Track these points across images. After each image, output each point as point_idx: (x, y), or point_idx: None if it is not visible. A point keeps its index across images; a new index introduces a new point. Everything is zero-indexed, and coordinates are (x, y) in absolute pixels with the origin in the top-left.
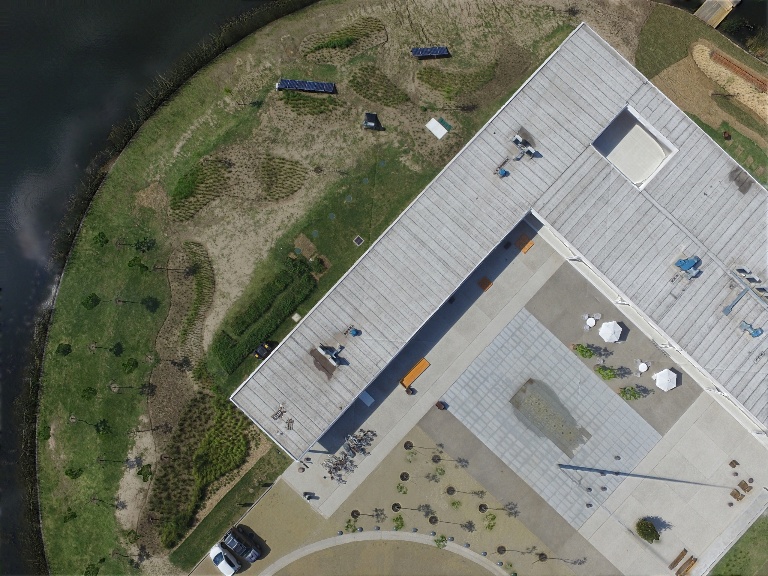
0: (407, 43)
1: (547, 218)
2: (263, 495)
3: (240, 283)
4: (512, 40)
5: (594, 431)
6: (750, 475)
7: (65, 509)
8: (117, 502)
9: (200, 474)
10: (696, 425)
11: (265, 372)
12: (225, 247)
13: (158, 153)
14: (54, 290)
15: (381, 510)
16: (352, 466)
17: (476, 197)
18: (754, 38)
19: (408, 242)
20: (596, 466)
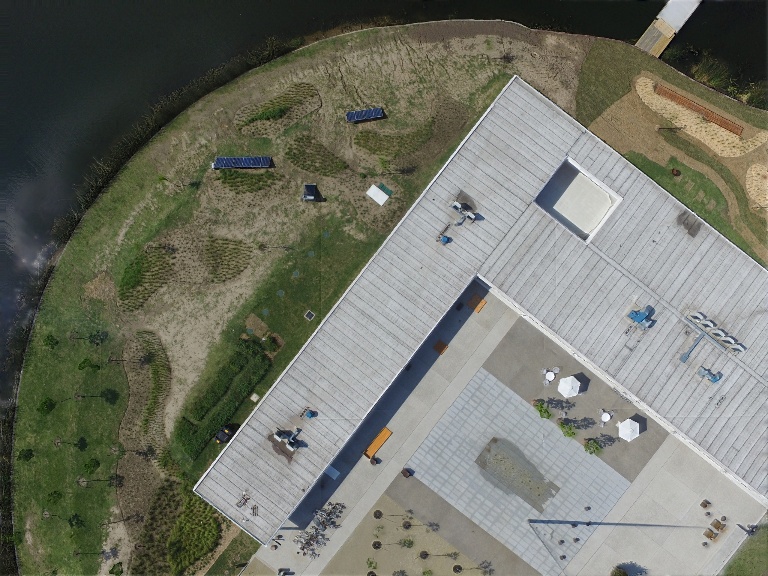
0: (342, 107)
1: (494, 281)
2: (239, 575)
3: (196, 368)
4: (448, 95)
5: (562, 484)
6: (722, 513)
7: None
8: None
9: (174, 561)
10: (664, 468)
11: (225, 461)
12: (177, 333)
13: (103, 242)
14: (15, 387)
15: None
16: (324, 539)
17: (420, 267)
18: (699, 64)
19: (356, 319)
20: (567, 518)
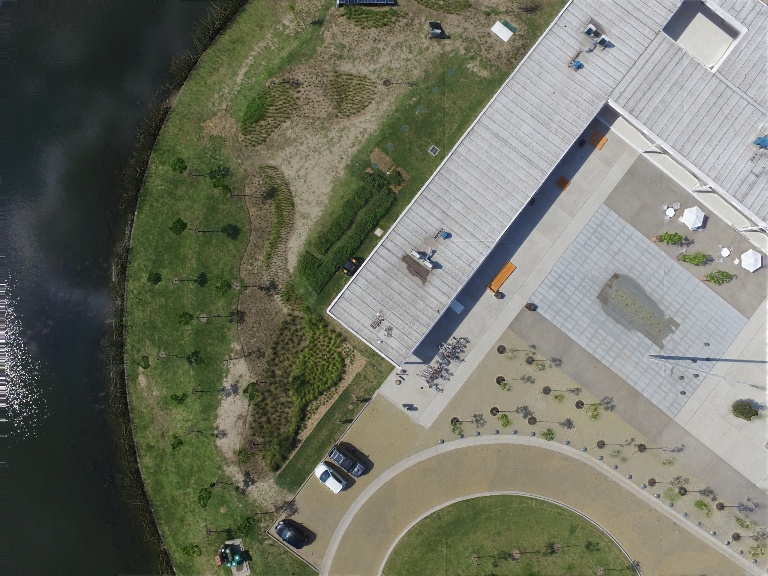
0: None
1: (625, 107)
2: (362, 411)
3: (319, 203)
4: None
5: (682, 320)
6: None
7: (163, 445)
8: (217, 431)
9: (299, 394)
10: None
11: (359, 282)
12: (301, 168)
13: (221, 82)
14: (128, 230)
15: (480, 415)
16: (448, 374)
17: (553, 91)
18: None
19: (490, 141)
20: (686, 354)
